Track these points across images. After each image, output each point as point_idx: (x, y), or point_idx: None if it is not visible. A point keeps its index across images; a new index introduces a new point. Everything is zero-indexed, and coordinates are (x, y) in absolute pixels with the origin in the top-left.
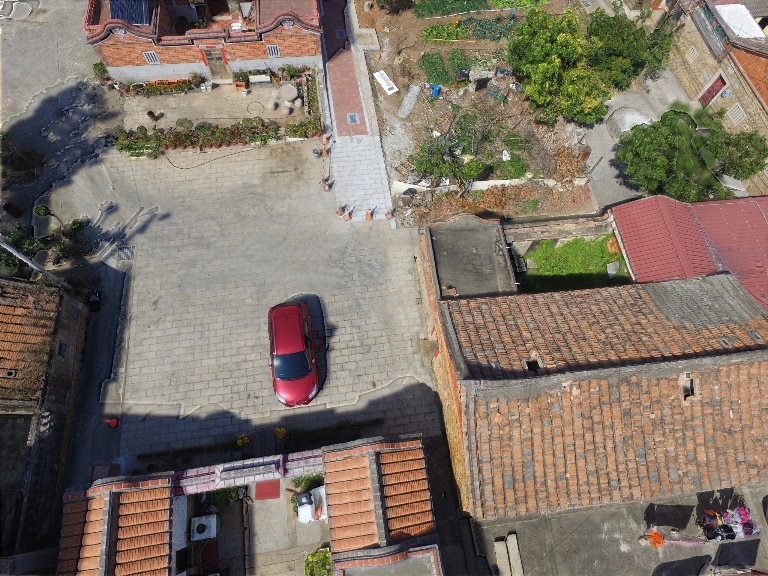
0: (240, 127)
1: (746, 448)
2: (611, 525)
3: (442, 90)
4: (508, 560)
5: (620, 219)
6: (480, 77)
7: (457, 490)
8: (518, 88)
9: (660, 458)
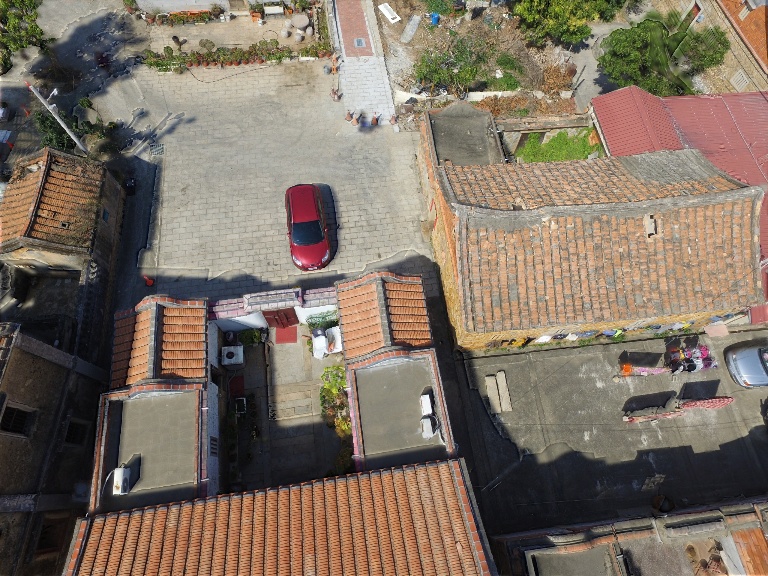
0: (257, 48)
1: (702, 280)
2: (589, 367)
3: (441, 19)
4: (497, 391)
5: (598, 108)
6: (476, 5)
7: (453, 332)
8: (511, 17)
9: (627, 286)
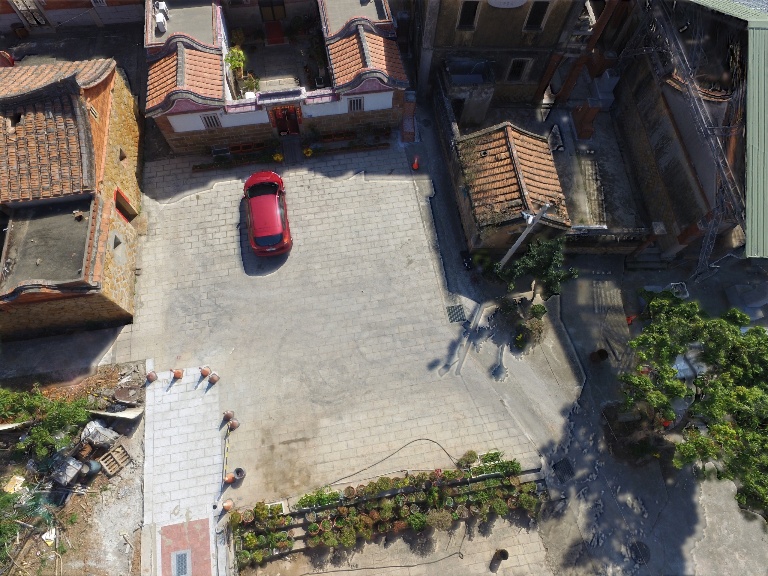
0: (358, 525)
1: None
2: None
3: None
4: None
5: None
6: None
7: None
8: None
9: None
